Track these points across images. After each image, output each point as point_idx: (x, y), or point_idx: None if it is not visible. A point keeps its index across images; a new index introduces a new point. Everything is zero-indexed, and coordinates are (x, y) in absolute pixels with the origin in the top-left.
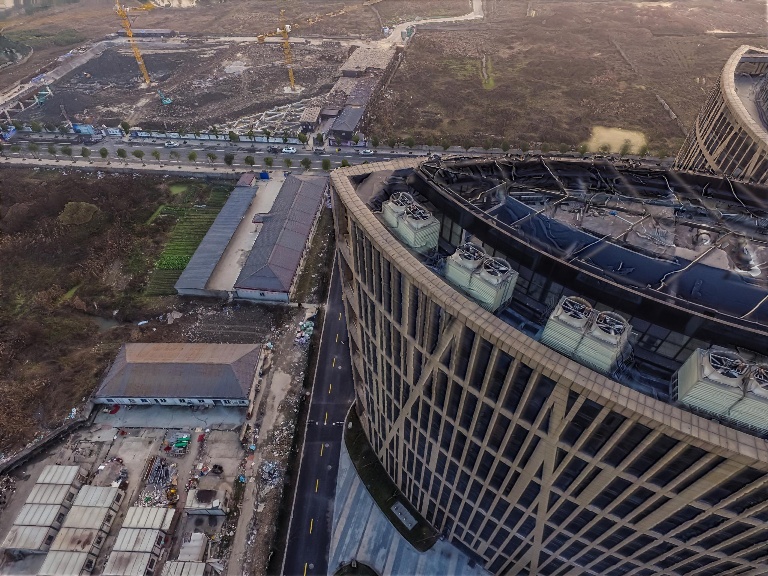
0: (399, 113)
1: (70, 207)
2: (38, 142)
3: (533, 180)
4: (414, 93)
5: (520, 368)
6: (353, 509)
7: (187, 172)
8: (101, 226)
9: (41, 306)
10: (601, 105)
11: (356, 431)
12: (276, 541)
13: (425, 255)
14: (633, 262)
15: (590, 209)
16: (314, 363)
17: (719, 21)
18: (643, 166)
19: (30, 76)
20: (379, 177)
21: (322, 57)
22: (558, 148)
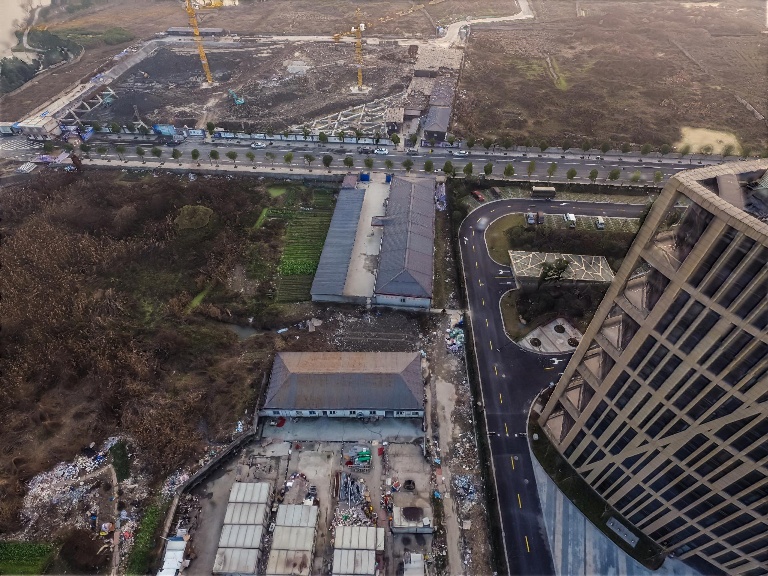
0: (480, 113)
1: (187, 211)
2: (118, 143)
3: None
4: (488, 93)
5: None
6: (566, 525)
7: (284, 174)
8: (211, 230)
9: (173, 314)
10: (682, 105)
11: (543, 443)
12: (499, 561)
13: None
14: None
15: None
16: (476, 372)
17: None
18: None
19: (89, 75)
20: (730, 182)
21: (383, 57)
22: (653, 149)
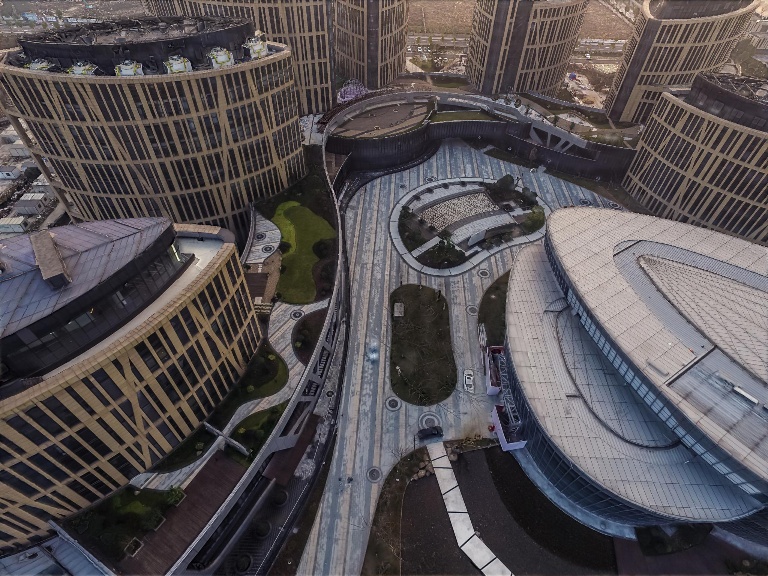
0: None
1: None
2: None
3: None
4: None
5: None
6: None
7: None
8: None
9: None
10: None
11: None
12: None
13: None
14: None
15: None
16: None
17: None
18: None
19: None
20: None
21: None
22: None
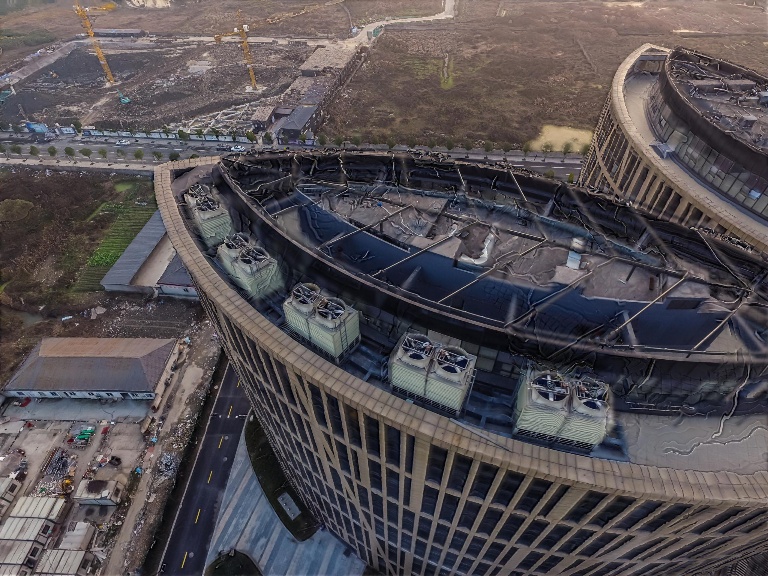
0: (354, 112)
1: (5, 204)
2: None
3: (326, 173)
4: (372, 92)
5: (263, 352)
6: (241, 500)
7: (133, 170)
8: (40, 223)
9: None
10: (554, 104)
11: (256, 424)
12: (159, 530)
13: (209, 245)
14: (377, 251)
15: (364, 200)
16: None
17: (687, 21)
18: (448, 160)
19: None
20: (201, 171)
21: (287, 57)
22: None
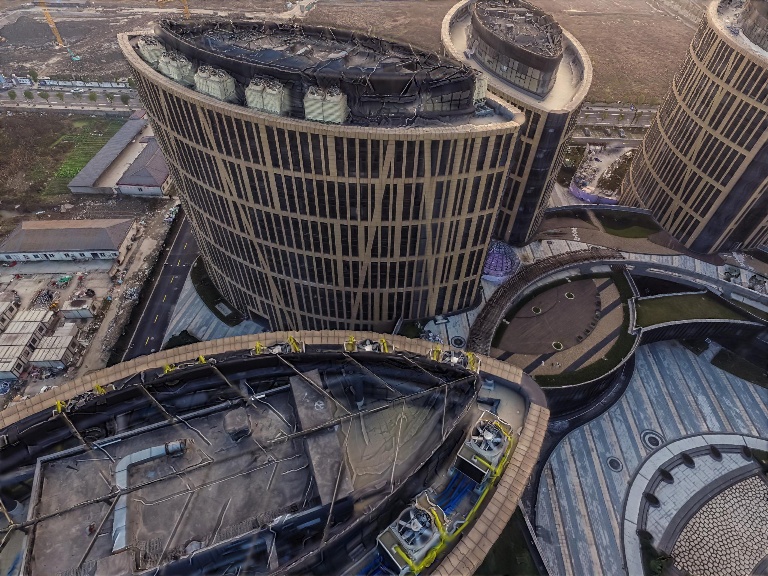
0: None
1: None
2: None
3: None
4: None
5: (185, 105)
6: (188, 309)
7: (88, 110)
8: (8, 149)
9: None
10: None
11: (199, 268)
12: (127, 325)
13: (154, 64)
14: None
15: (243, 37)
16: (176, 232)
17: (577, 3)
18: None
19: None
20: None
21: None
22: None
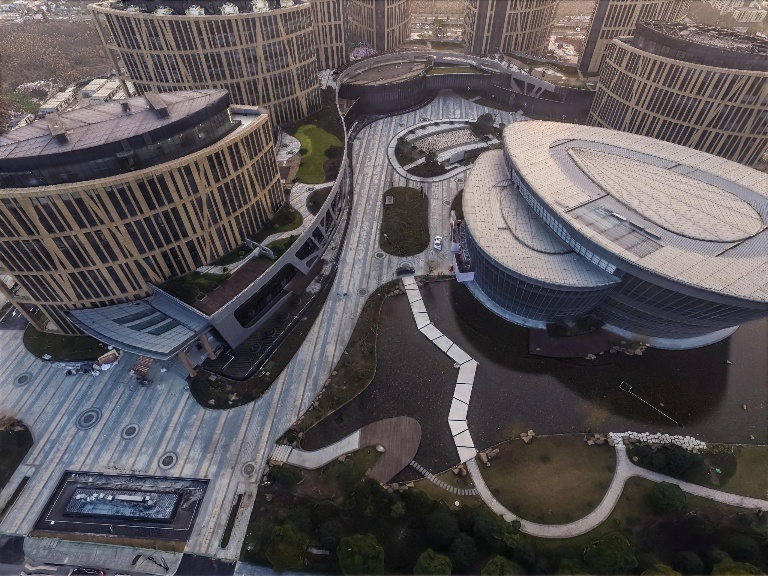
0: None
1: None
2: None
3: None
4: None
5: None
6: None
7: None
8: None
9: None
10: None
11: None
12: None
13: None
14: None
15: None
16: None
17: None
18: None
19: None
20: None
21: None
22: None
